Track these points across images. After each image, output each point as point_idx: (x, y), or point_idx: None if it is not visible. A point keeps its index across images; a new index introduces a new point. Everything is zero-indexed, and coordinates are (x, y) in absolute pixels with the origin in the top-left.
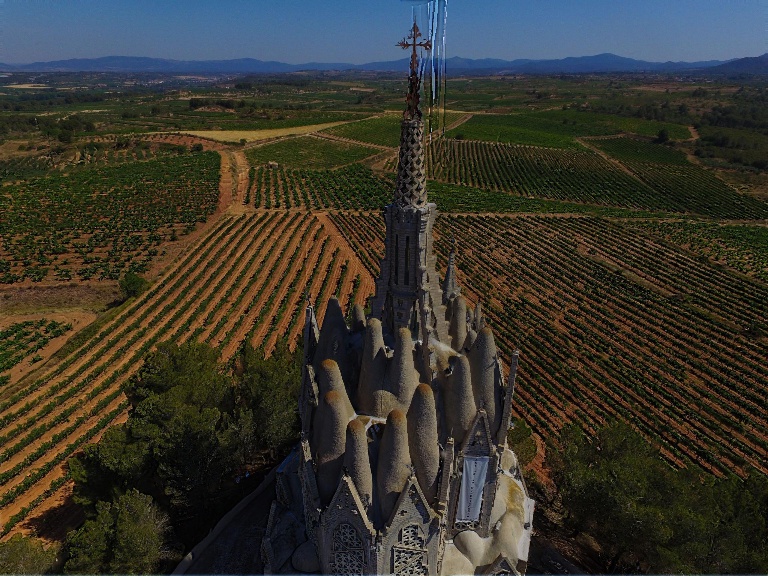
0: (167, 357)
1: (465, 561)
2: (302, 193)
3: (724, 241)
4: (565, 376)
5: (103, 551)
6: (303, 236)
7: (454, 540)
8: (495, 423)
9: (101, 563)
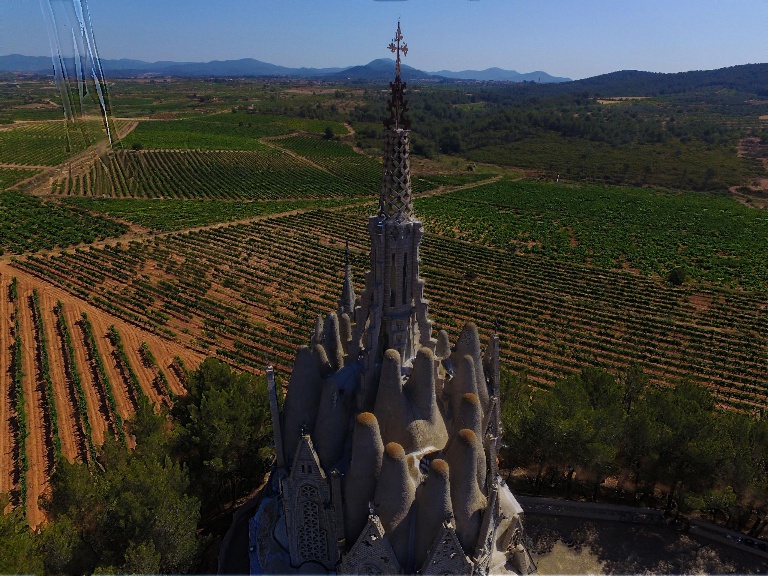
0: None
1: None
2: None
3: None
4: None
5: None
6: None
7: None
8: None
9: None
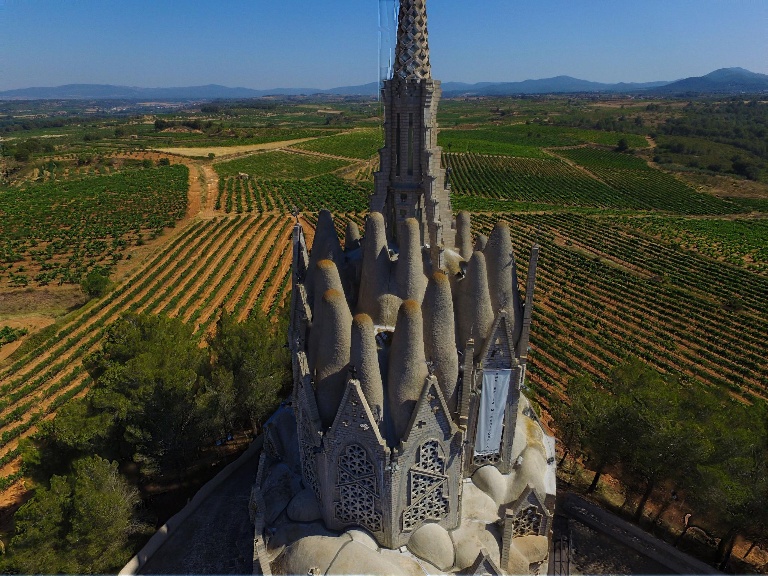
0: (134, 327)
1: (487, 499)
2: (274, 199)
3: (692, 232)
4: (557, 351)
5: (58, 525)
6: (278, 235)
7: (472, 478)
8: (515, 332)
9: (56, 539)
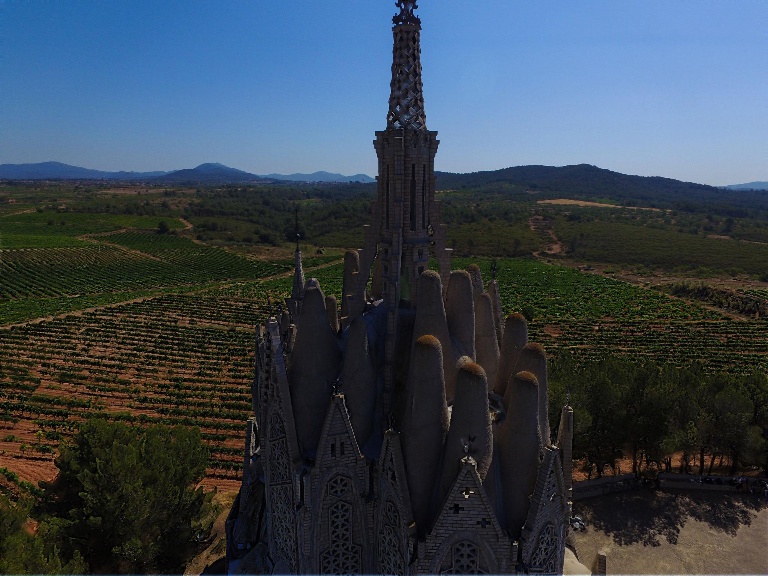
0: None
1: None
2: None
3: (275, 290)
4: None
5: None
6: None
7: None
8: None
9: None
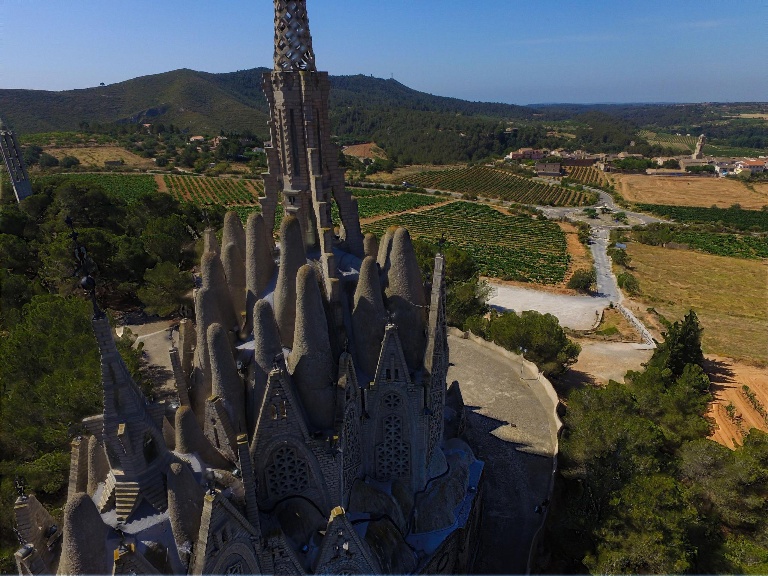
0: None
1: None
2: None
3: None
4: None
5: None
6: None
7: None
8: None
9: None
